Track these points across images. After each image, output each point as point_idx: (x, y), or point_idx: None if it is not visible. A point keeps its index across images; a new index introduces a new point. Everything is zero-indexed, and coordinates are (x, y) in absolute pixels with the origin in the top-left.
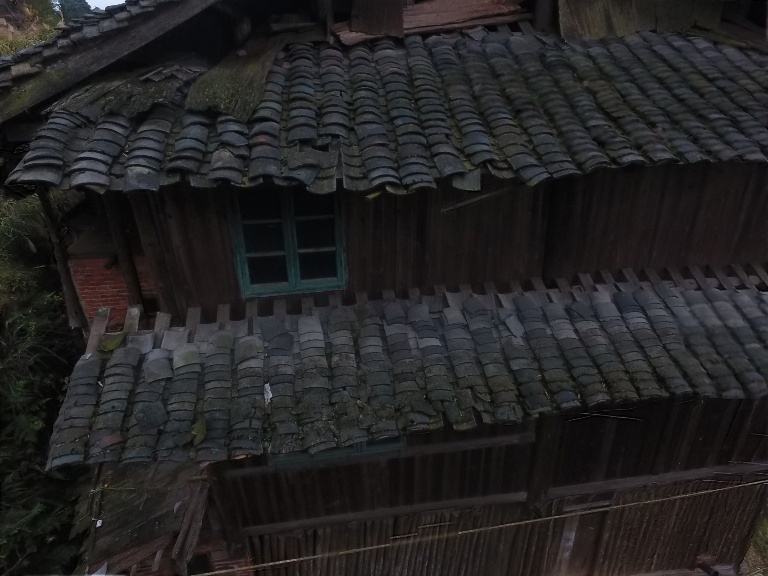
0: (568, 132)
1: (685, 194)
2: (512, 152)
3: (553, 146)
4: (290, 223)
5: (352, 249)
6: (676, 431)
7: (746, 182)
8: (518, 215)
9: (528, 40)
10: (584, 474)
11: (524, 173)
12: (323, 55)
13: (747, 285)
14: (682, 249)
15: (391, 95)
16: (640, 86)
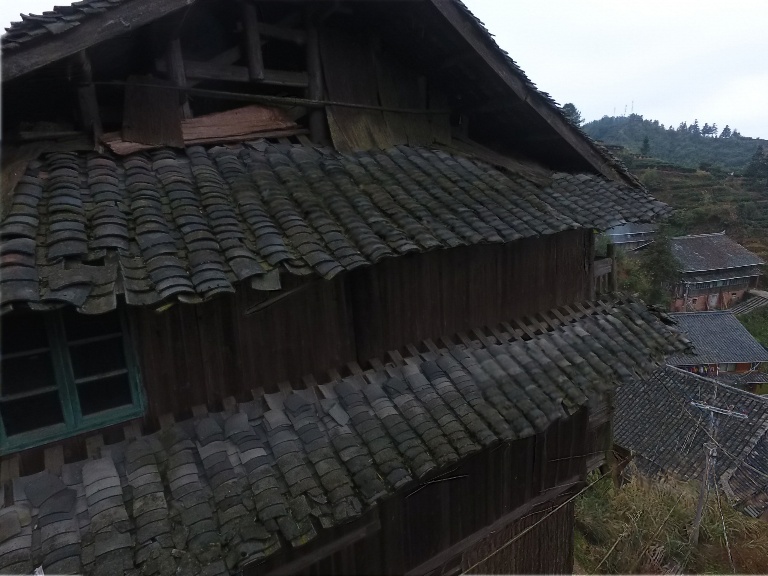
0: (353, 229)
1: (456, 271)
2: (306, 250)
3: (342, 242)
4: (61, 350)
5: (149, 367)
6: (496, 477)
7: (496, 257)
8: (324, 306)
9: (307, 151)
10: (432, 547)
11: (320, 268)
12: (91, 164)
13: (516, 337)
14: (464, 316)
15: (176, 203)
16: (404, 188)
